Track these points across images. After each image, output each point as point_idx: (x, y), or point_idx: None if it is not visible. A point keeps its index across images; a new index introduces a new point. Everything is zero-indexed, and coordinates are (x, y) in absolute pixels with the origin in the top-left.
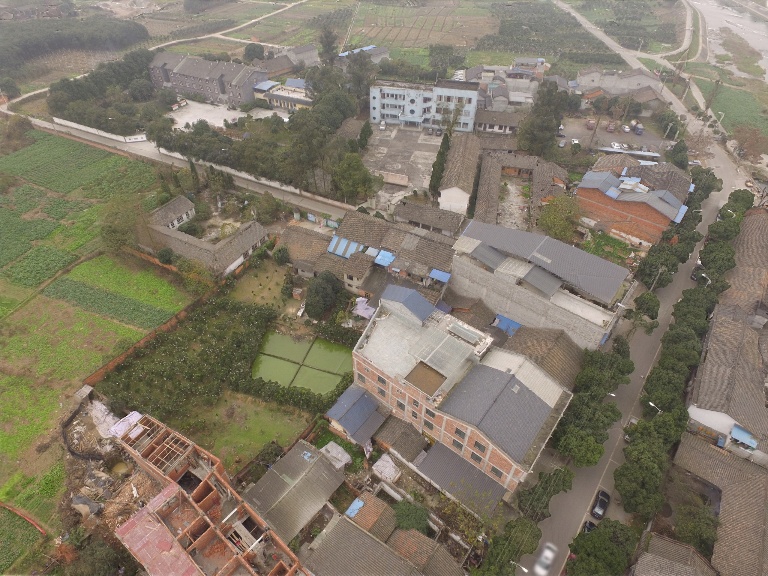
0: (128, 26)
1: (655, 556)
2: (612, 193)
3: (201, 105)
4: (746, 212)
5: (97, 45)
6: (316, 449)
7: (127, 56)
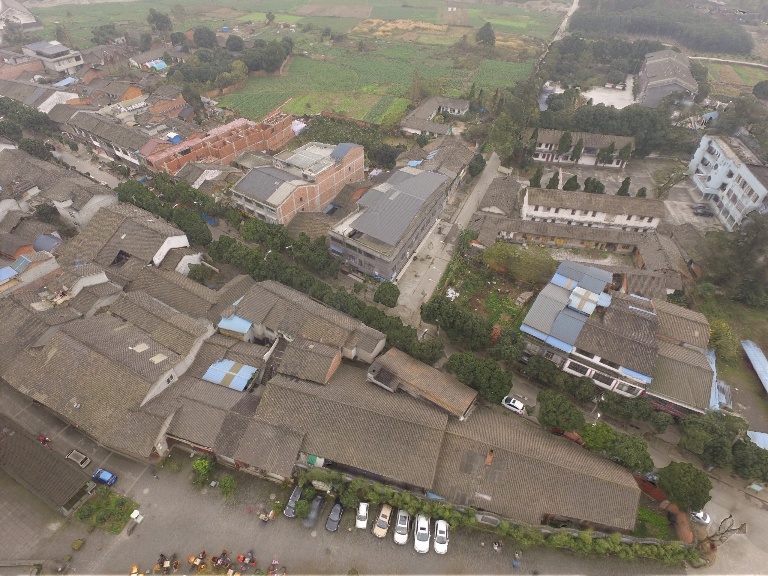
0: (731, 36)
1: (182, 234)
2: (561, 280)
3: (629, 95)
4: (681, 514)
5: (688, 41)
6: None
7: (638, 41)
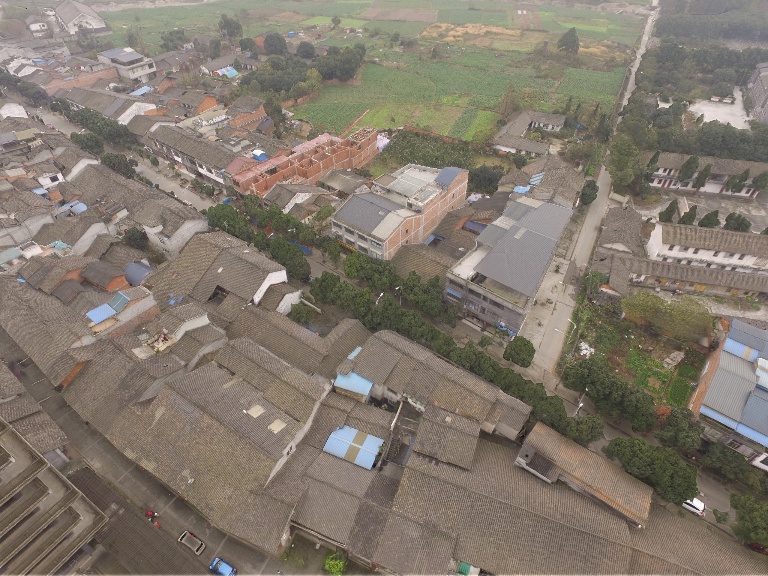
0: None
1: (282, 269)
2: (736, 347)
3: (740, 110)
4: None
5: None
6: (365, 182)
7: (748, 49)
